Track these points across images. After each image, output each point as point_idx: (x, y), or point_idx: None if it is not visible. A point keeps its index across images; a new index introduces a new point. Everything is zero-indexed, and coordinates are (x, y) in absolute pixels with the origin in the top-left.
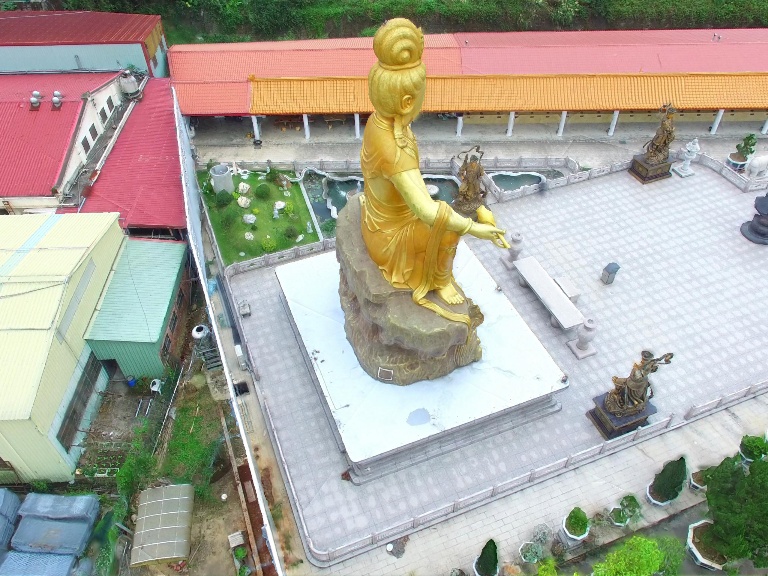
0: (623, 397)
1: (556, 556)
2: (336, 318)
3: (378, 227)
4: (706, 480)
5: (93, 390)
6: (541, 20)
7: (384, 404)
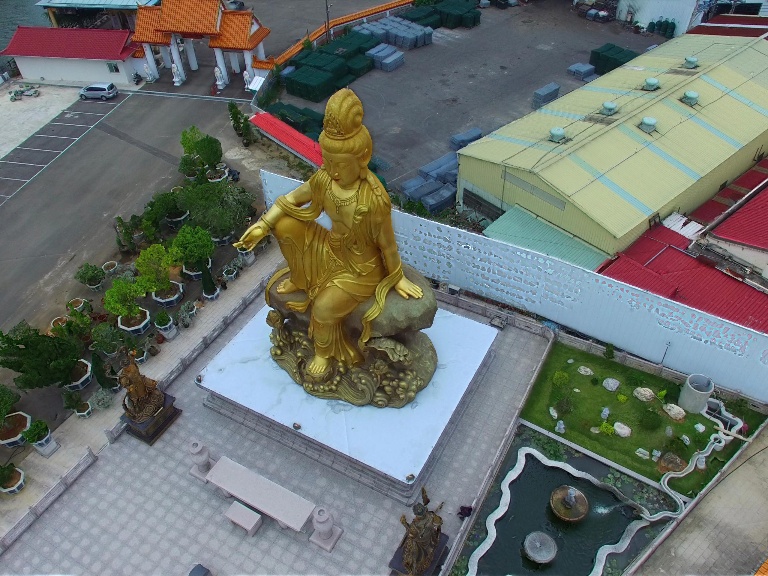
0: None
1: None
2: None
3: None
4: None
5: None
6: None
7: None
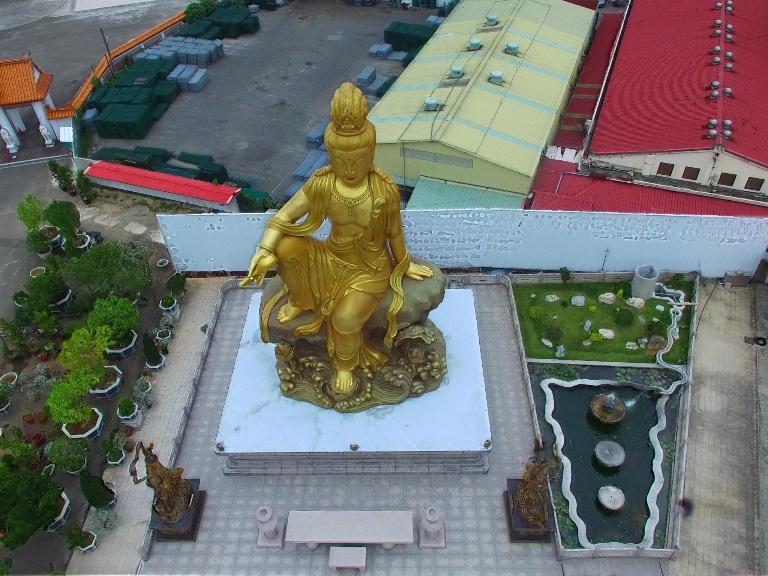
0: None
1: None
2: None
3: None
4: None
5: (405, 202)
6: None
7: None
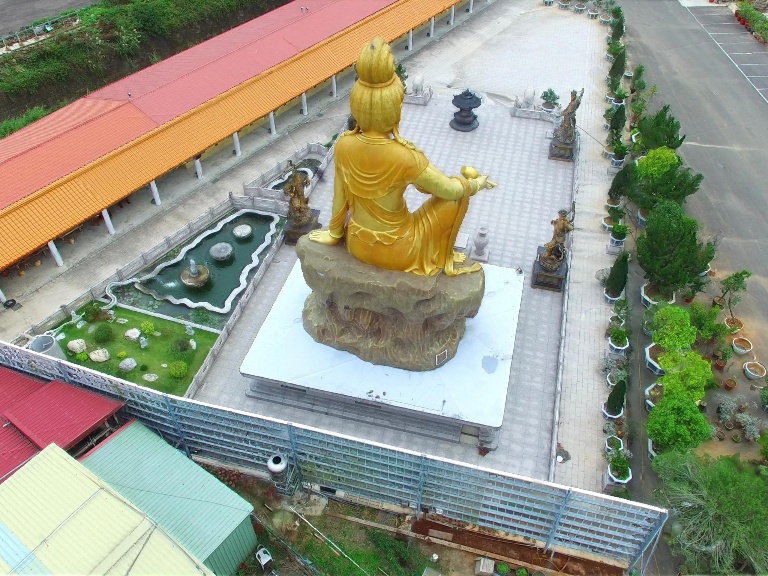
0: (557, 254)
1: (623, 369)
2: (346, 360)
3: (396, 237)
4: (639, 259)
5: None
6: (109, 59)
7: (462, 378)
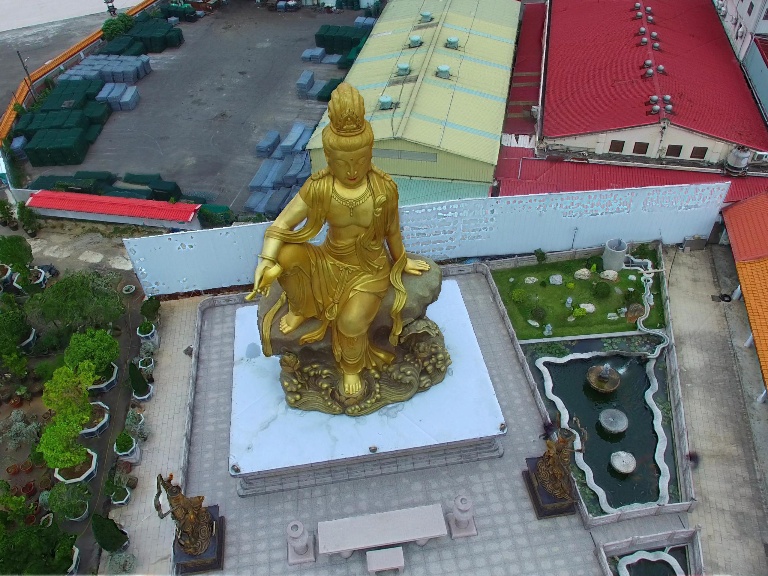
0: None
1: None
2: None
3: None
4: None
5: None
6: None
7: None
